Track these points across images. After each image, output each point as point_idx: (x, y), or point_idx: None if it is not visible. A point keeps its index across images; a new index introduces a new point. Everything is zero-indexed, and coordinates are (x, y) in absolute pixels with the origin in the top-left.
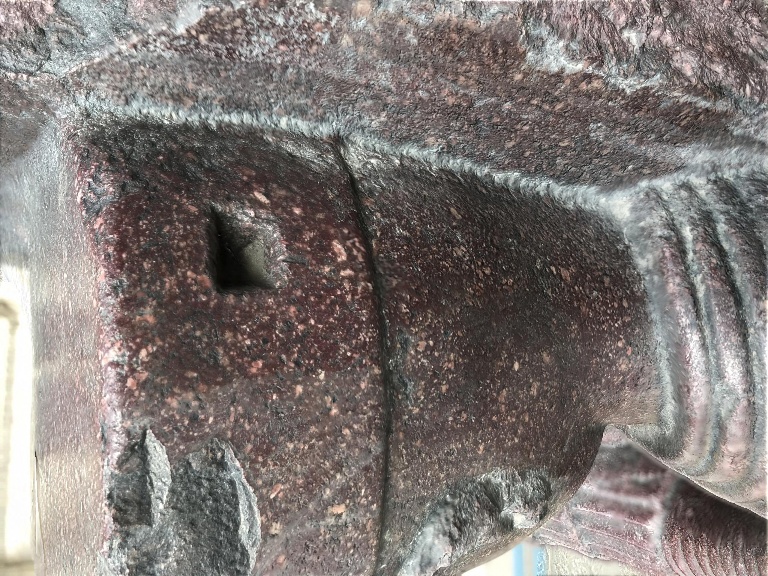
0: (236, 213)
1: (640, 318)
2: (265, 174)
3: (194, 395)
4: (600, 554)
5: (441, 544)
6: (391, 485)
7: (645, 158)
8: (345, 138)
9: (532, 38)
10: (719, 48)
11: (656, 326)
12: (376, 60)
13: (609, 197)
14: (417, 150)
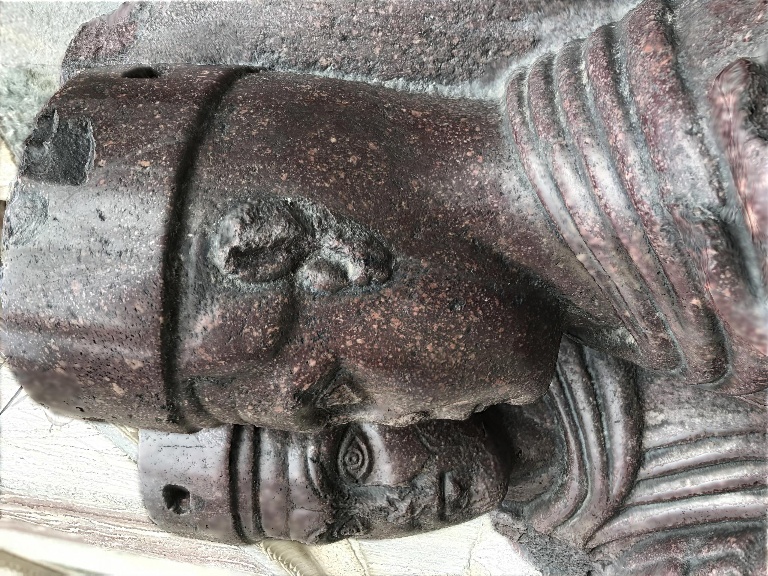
0: (162, 70)
1: (492, 137)
2: None
3: (83, 100)
4: None
5: (233, 223)
6: (197, 174)
7: (494, 40)
8: (268, 68)
9: None
10: None
11: (507, 139)
12: (261, 6)
13: (494, 88)
14: (319, 71)
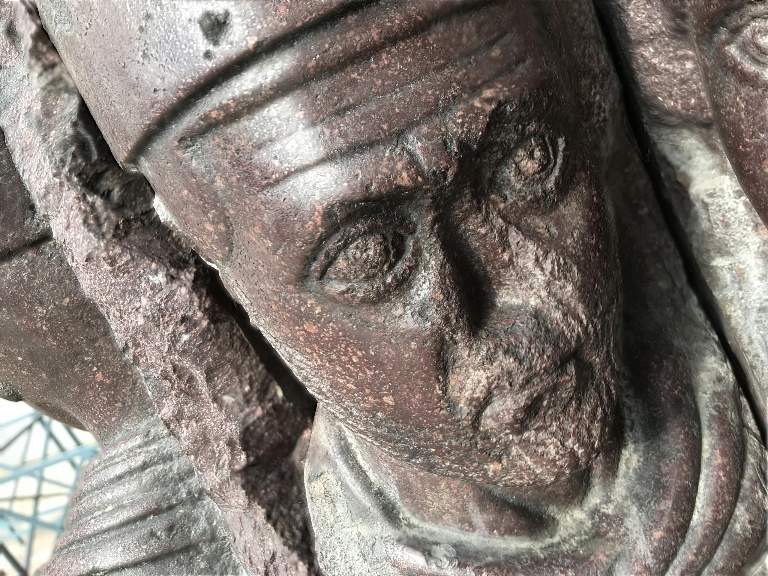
0: None
1: (112, 431)
2: (1, 200)
3: None
4: None
5: None
6: None
7: None
8: None
9: (100, 308)
10: (199, 431)
11: (113, 441)
12: None
13: None
14: None
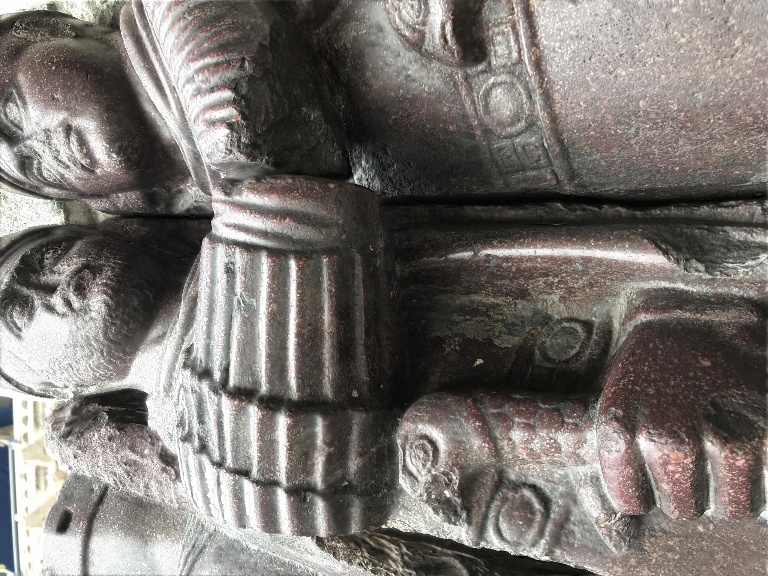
0: None
1: None
2: None
3: None
4: None
5: None
6: None
7: None
8: None
9: (101, 479)
10: None
11: None
12: None
13: None
14: None
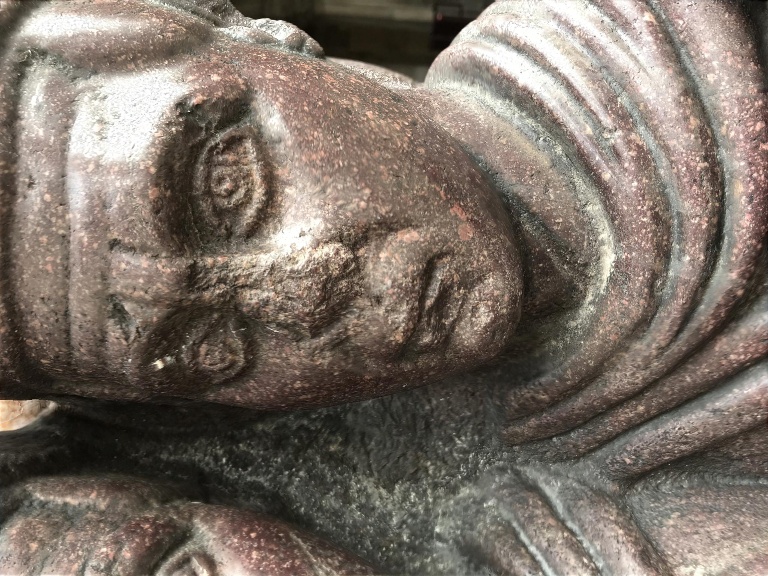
0: None
1: None
2: None
3: None
4: None
5: None
6: None
7: None
8: None
9: None
10: None
11: None
12: None
13: None
14: None
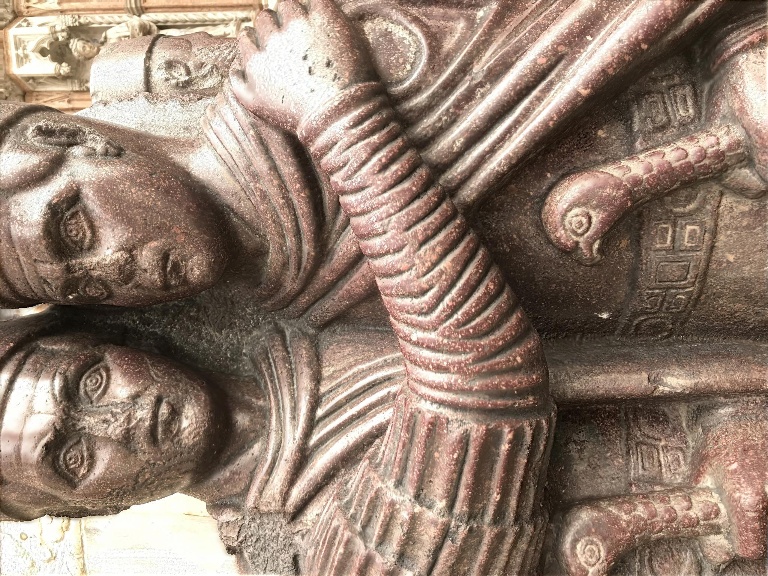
0: None
1: None
2: None
3: None
4: (418, 502)
5: None
6: None
7: None
8: None
9: None
10: None
11: None
12: None
13: None
14: None
